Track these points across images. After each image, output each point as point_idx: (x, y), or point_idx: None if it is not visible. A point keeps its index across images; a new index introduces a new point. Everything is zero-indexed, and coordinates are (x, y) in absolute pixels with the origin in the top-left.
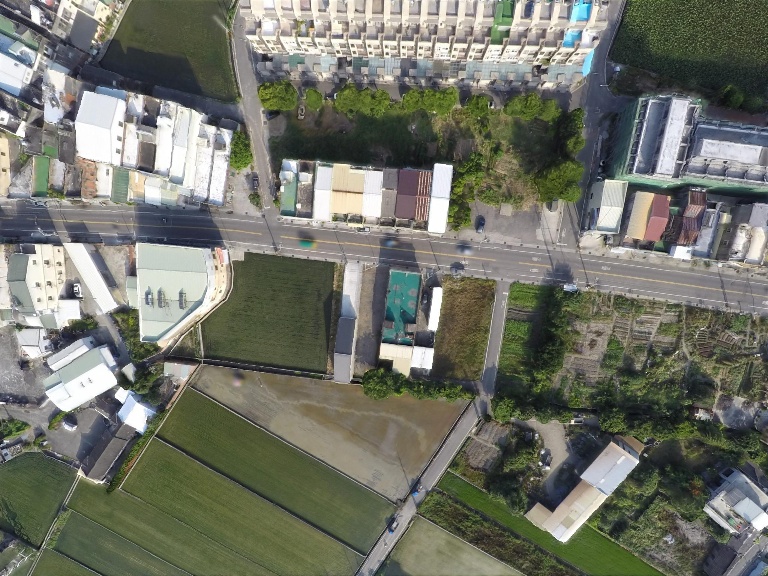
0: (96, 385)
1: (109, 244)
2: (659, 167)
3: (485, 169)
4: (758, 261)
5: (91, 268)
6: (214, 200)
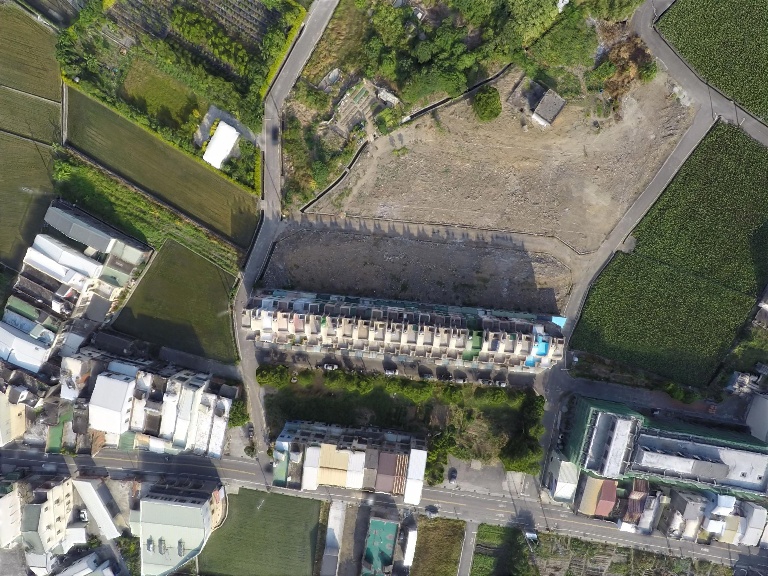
0: None
1: (115, 478)
2: (606, 471)
3: (458, 430)
4: (693, 538)
5: (97, 503)
6: (213, 453)
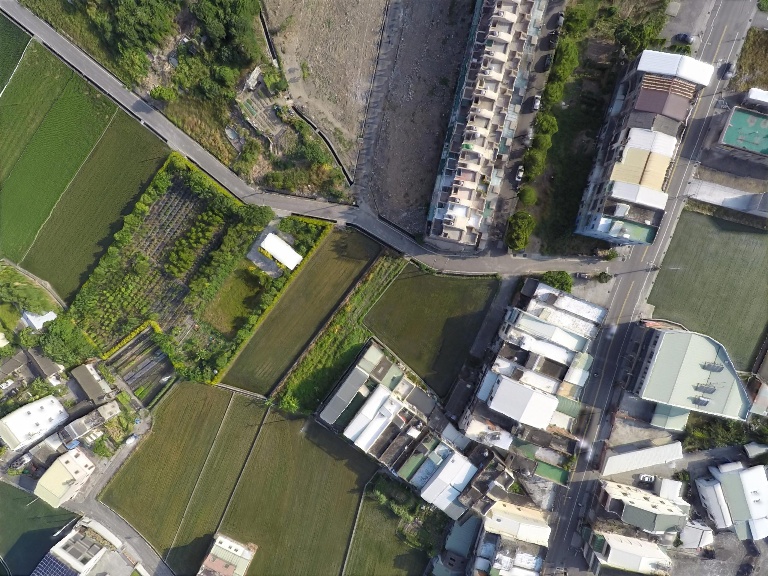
0: (759, 488)
1: (608, 435)
2: None
3: None
4: None
5: (635, 456)
6: (598, 318)
